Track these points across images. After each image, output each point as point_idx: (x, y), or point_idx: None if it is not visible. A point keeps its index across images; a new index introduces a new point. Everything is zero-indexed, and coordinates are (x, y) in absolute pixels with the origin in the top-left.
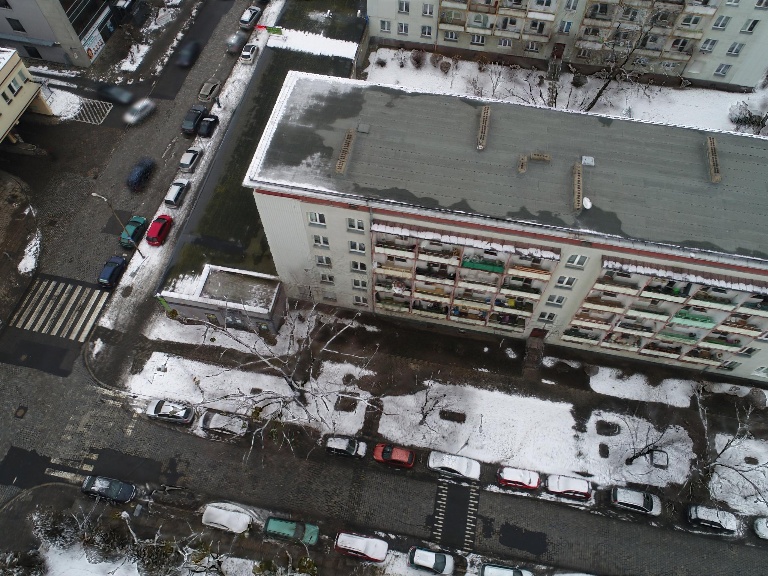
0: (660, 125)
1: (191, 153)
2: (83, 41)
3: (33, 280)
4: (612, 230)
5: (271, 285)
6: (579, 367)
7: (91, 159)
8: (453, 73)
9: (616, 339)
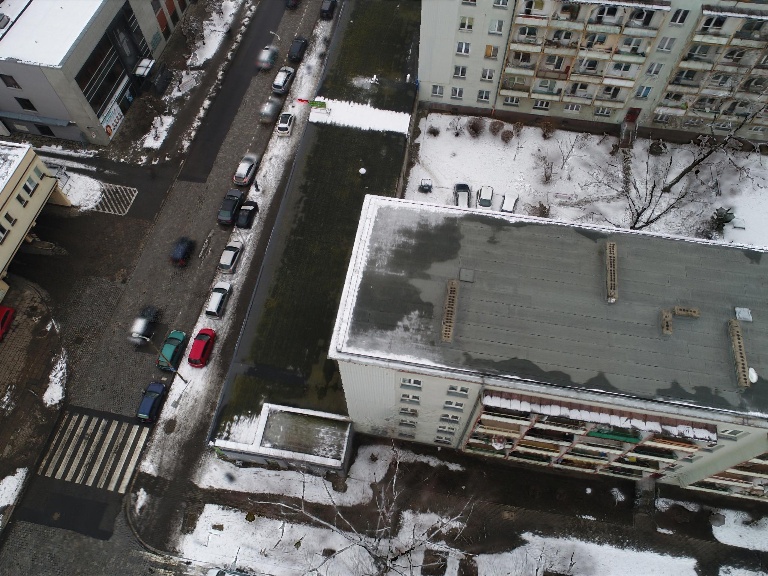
0: None
1: (231, 251)
2: (101, 118)
3: (61, 414)
4: None
5: (341, 427)
6: (698, 510)
7: (118, 258)
8: (518, 146)
9: (751, 491)
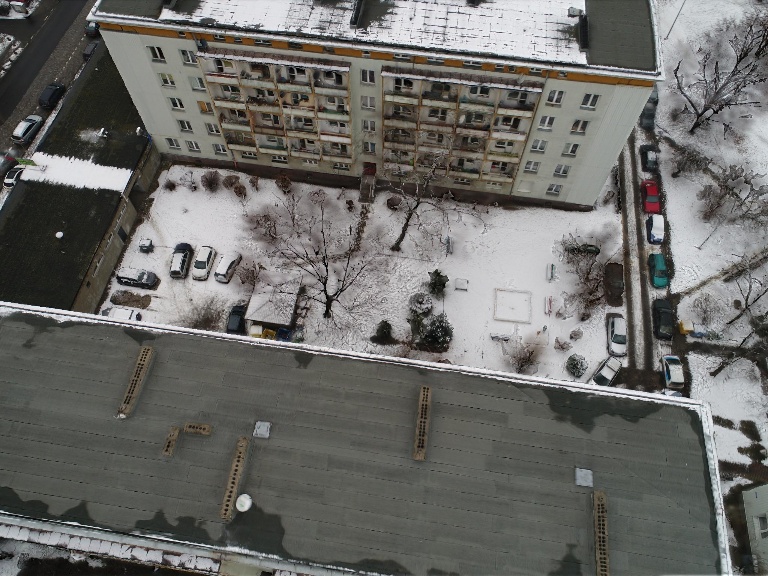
0: (372, 362)
1: None
2: None
3: None
4: (269, 546)
5: None
6: None
7: None
8: (243, 203)
9: None
